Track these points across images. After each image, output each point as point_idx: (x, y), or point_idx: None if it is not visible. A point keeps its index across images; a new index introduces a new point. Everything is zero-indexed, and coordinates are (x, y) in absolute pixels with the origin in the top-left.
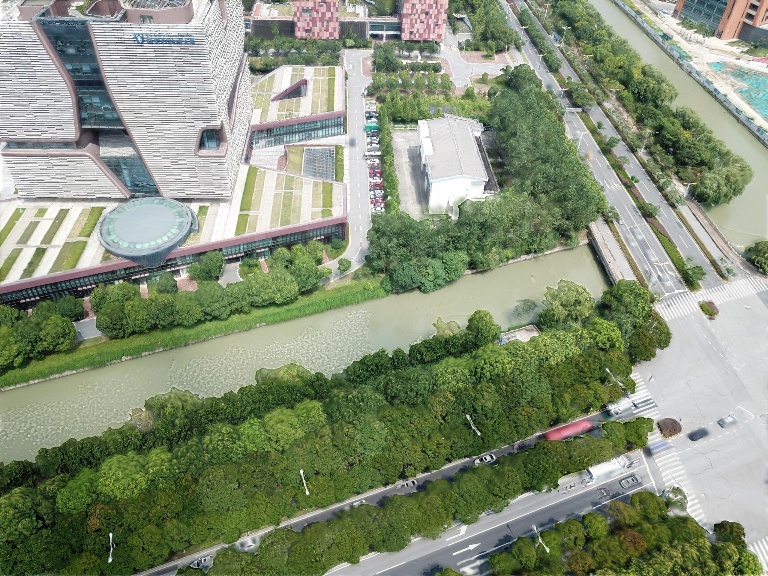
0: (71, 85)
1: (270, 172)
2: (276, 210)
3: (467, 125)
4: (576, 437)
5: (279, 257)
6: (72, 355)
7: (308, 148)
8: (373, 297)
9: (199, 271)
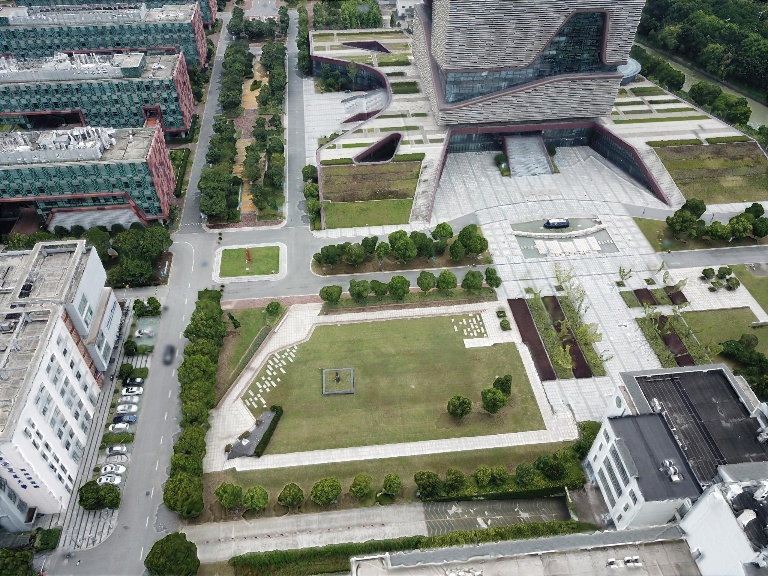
0: None
1: None
2: None
3: None
4: None
5: None
6: None
7: None
8: None
9: None
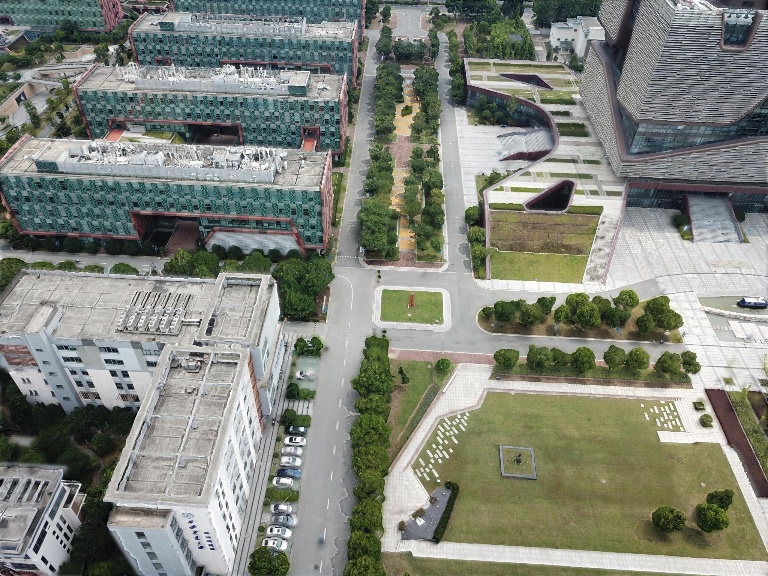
0: None
1: None
2: None
3: (584, 18)
4: None
5: None
6: None
7: None
8: None
9: None
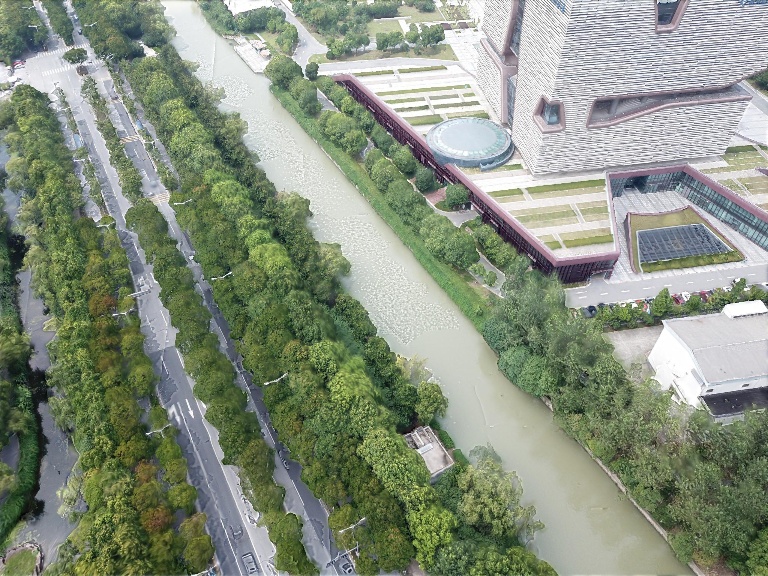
0: (514, 8)
1: (605, 195)
2: (540, 210)
3: None
4: (282, 488)
5: None
6: (351, 162)
7: (705, 227)
8: (473, 321)
9: None
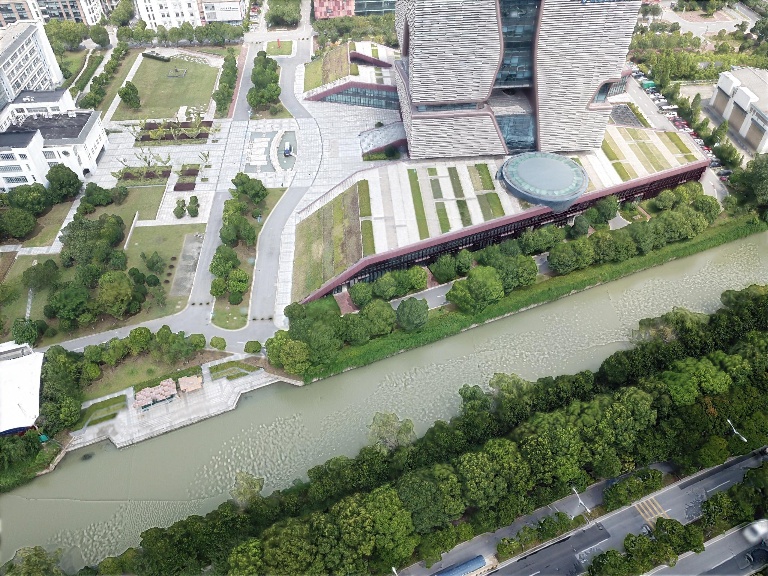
0: (503, 47)
1: (608, 126)
2: (642, 158)
3: (767, 74)
4: None
5: (668, 198)
6: (530, 291)
7: None
8: (758, 231)
9: (597, 215)
